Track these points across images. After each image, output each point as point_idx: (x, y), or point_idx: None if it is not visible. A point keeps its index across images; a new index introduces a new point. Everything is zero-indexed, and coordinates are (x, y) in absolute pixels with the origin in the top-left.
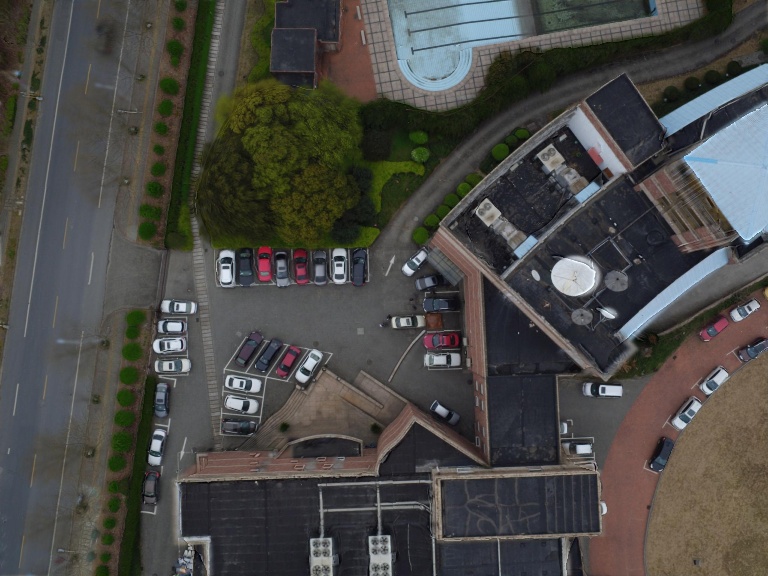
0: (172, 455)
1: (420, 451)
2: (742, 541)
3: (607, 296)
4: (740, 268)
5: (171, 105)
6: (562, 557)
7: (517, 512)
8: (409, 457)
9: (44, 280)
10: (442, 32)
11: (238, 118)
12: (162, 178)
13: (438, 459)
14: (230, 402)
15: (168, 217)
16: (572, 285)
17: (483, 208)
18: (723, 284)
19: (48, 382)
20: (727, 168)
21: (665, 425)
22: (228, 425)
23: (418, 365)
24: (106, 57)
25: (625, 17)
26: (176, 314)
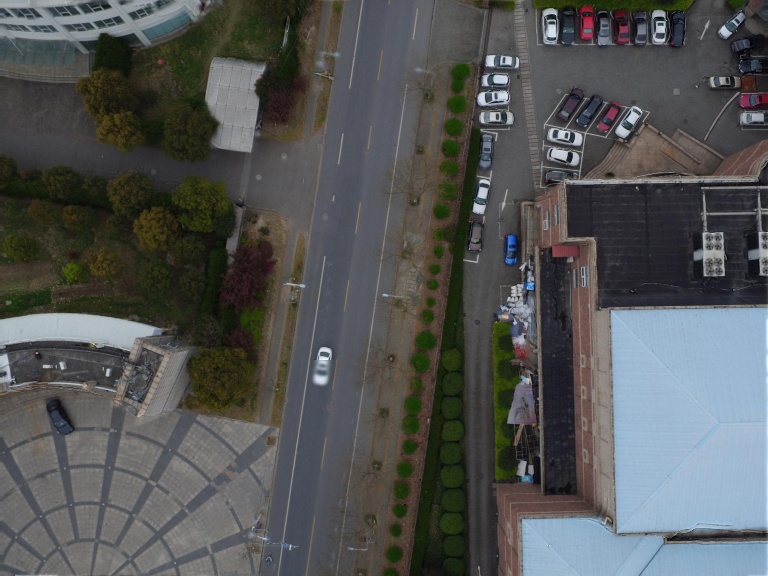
0: (494, 206)
1: None
2: None
3: None
4: None
5: None
6: None
7: None
8: None
9: (369, 34)
10: None
11: None
12: None
13: None
14: (555, 153)
15: None
16: None
17: None
18: None
19: (372, 132)
20: None
21: None
22: (554, 174)
23: (733, 125)
24: None
25: None
26: (500, 69)
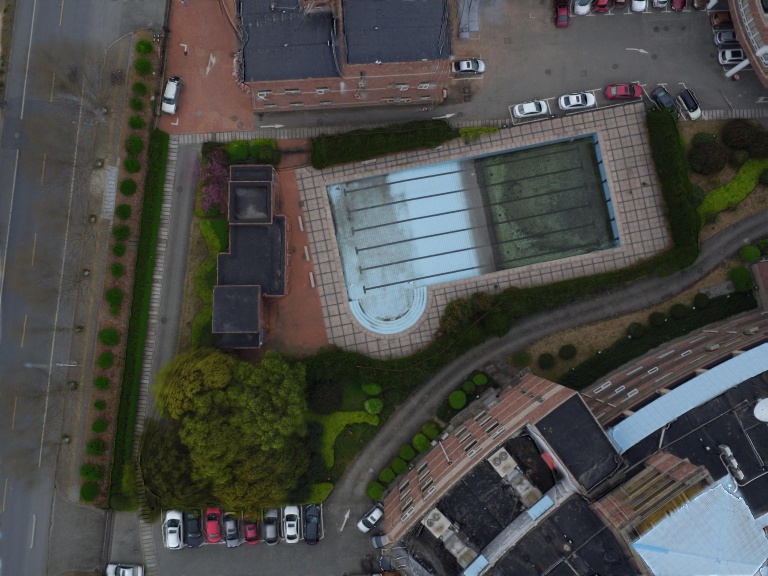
0: None
1: None
2: None
3: None
4: None
5: (112, 356)
6: None
7: None
8: None
9: None
10: (395, 269)
11: (176, 403)
12: (105, 433)
13: None
14: None
15: (111, 477)
16: None
17: (432, 518)
18: None
19: None
20: (678, 559)
21: None
22: None
23: None
24: (42, 307)
25: (587, 244)
26: None
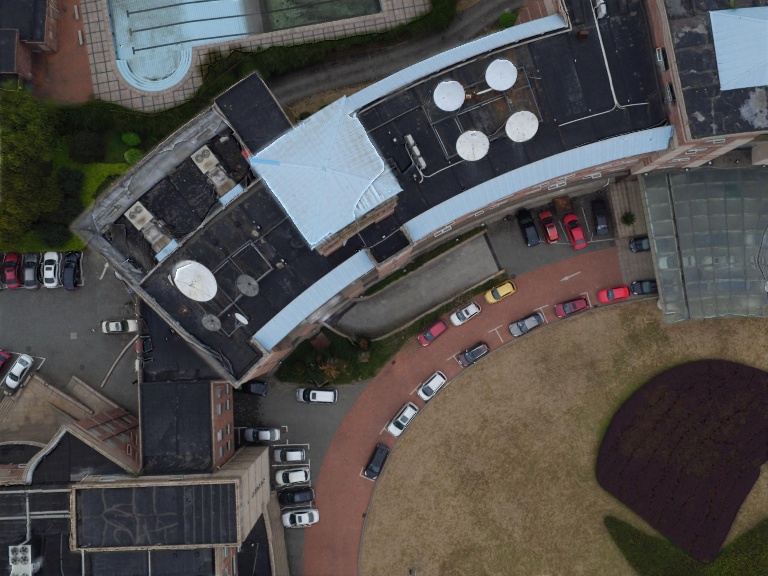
0: None
1: (75, 459)
2: (459, 550)
3: (246, 301)
4: (464, 271)
5: None
6: (215, 568)
7: (154, 522)
8: (64, 465)
9: None
10: (164, 31)
11: None
12: None
13: (92, 467)
14: None
15: None
16: (194, 290)
17: (134, 211)
18: (447, 287)
19: None
20: (289, 170)
21: (383, 431)
22: None
23: (130, 370)
24: None
25: (355, 15)
26: None
